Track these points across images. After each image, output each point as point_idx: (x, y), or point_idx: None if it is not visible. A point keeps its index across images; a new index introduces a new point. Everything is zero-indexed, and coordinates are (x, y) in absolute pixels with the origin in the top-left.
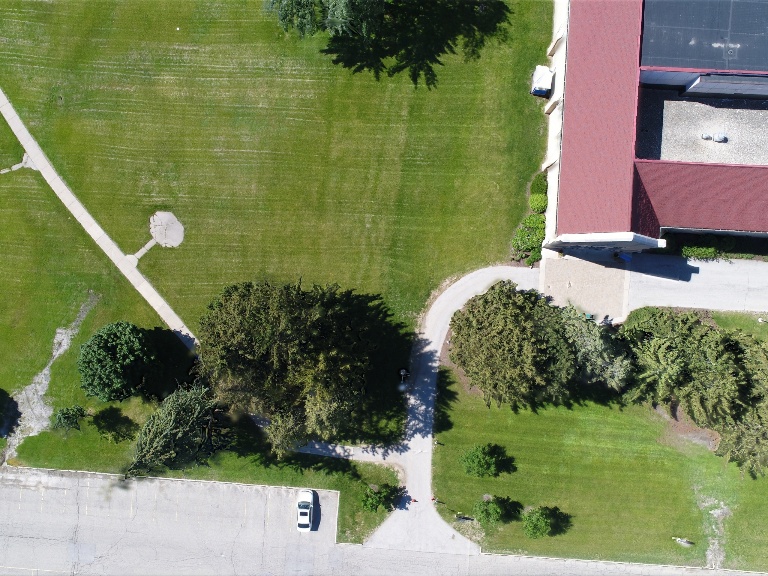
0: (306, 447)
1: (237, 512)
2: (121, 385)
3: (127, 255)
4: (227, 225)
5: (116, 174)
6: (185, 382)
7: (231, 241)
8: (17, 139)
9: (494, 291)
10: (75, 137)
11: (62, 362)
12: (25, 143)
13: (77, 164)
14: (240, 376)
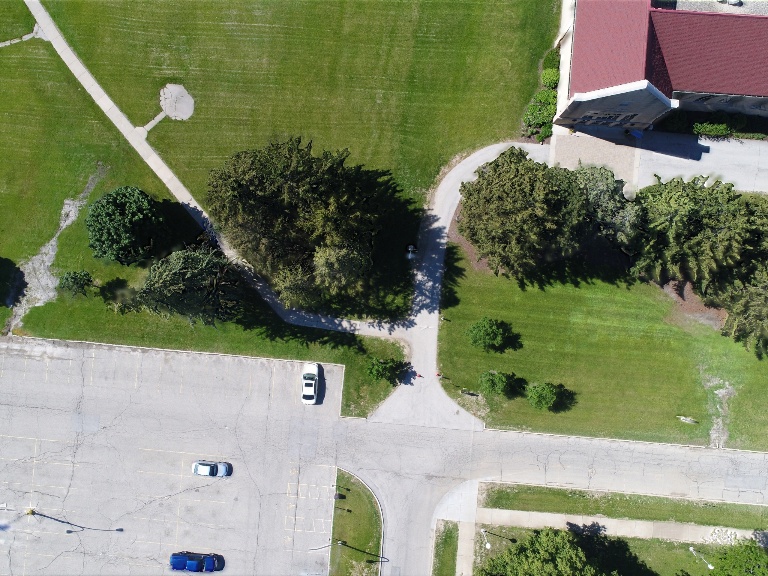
0: (312, 321)
1: (242, 385)
2: (129, 242)
3: (136, 127)
4: (237, 99)
5: (127, 46)
6: (193, 243)
7: (241, 115)
8: (28, 9)
9: (505, 154)
10: (87, 8)
11: (69, 233)
12: (36, 13)
13: (88, 35)
14: (250, 214)
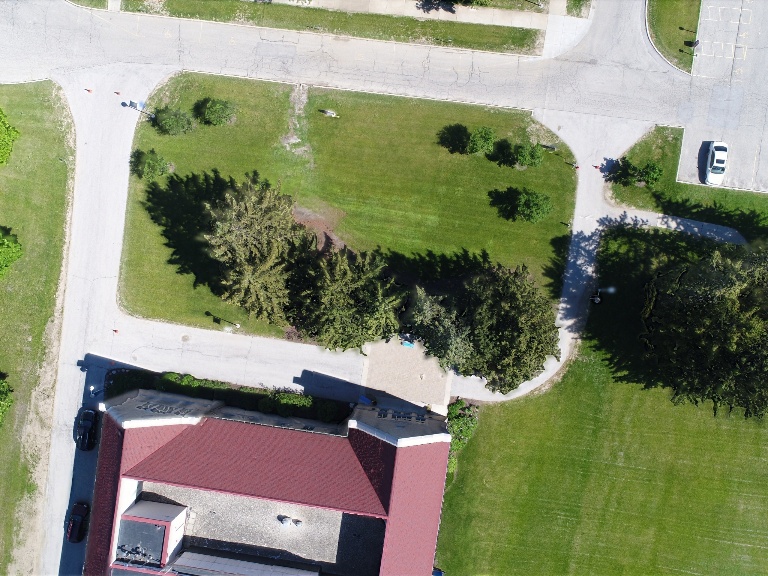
0: (708, 229)
1: None
2: None
3: None
4: None
5: None
6: None
7: None
8: None
9: None
10: None
11: None
12: None
13: None
14: None
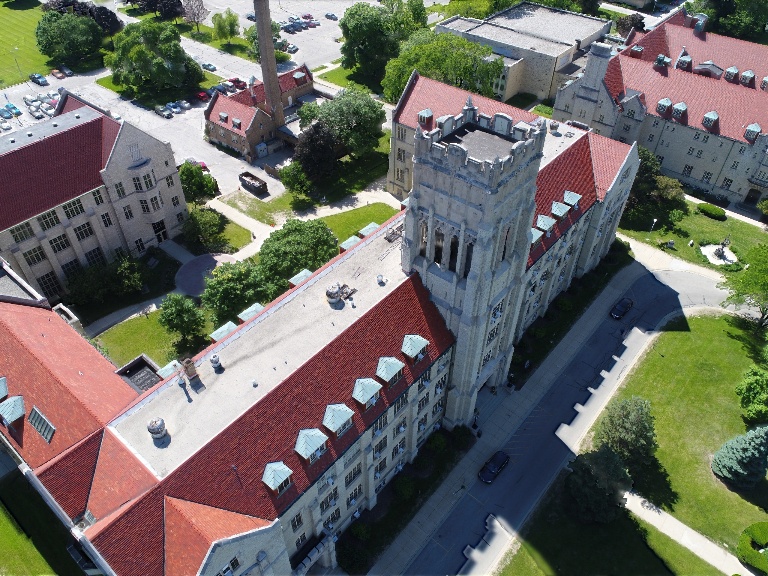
0: None
1: None
2: None
3: None
4: None
5: None
6: None
7: None
8: None
9: None
10: None
11: None
12: None
13: None
14: None
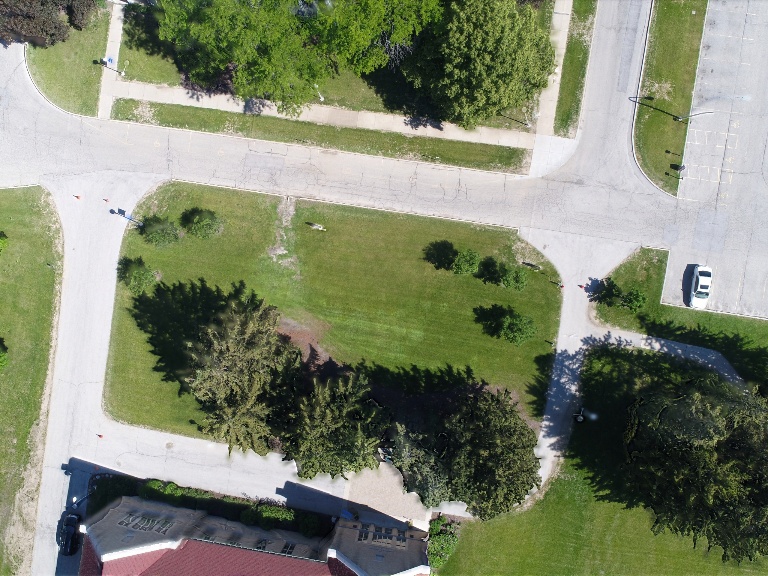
0: (691, 351)
1: None
2: None
3: None
4: None
5: None
6: None
7: (752, 574)
8: None
9: None
10: None
11: None
12: None
13: None
14: None
